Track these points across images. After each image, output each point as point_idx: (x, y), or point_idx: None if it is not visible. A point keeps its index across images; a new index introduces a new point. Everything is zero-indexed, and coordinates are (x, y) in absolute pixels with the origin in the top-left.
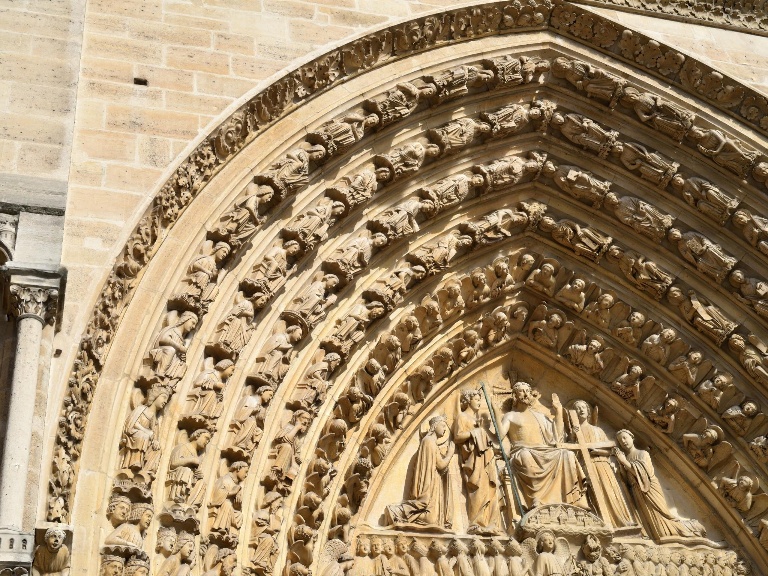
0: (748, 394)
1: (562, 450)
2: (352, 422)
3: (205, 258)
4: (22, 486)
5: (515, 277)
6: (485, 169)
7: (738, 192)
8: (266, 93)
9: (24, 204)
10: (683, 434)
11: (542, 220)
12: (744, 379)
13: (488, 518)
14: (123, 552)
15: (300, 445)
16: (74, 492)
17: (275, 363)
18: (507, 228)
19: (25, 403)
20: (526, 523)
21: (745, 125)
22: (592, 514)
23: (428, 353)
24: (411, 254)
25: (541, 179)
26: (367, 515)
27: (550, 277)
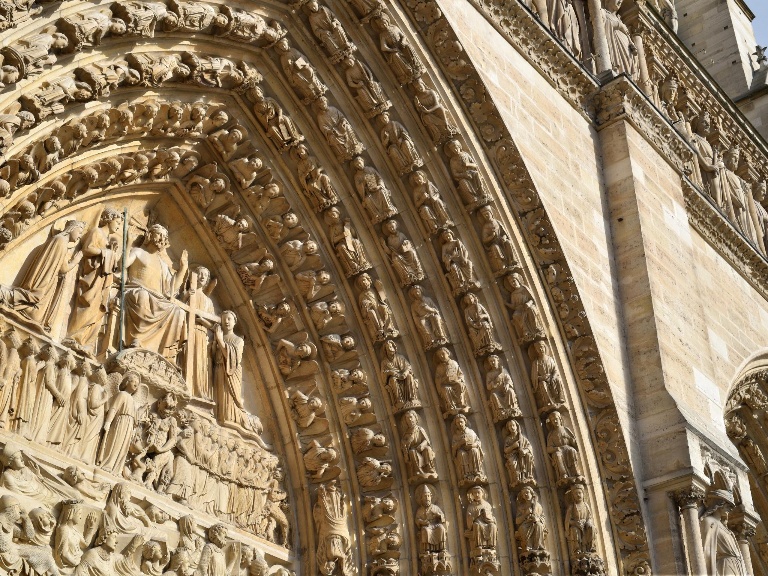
0: (351, 329)
1: (176, 305)
2: None
3: None
4: None
5: (202, 126)
6: (233, 14)
7: (426, 154)
8: None
9: None
10: (281, 338)
11: (254, 88)
12: (354, 315)
13: (86, 338)
14: None
15: None
16: None
17: None
18: (221, 78)
19: None
20: (122, 358)
21: (458, 101)
22: (180, 375)
23: (98, 157)
24: (133, 55)
25: (269, 50)
26: None
27: (234, 143)
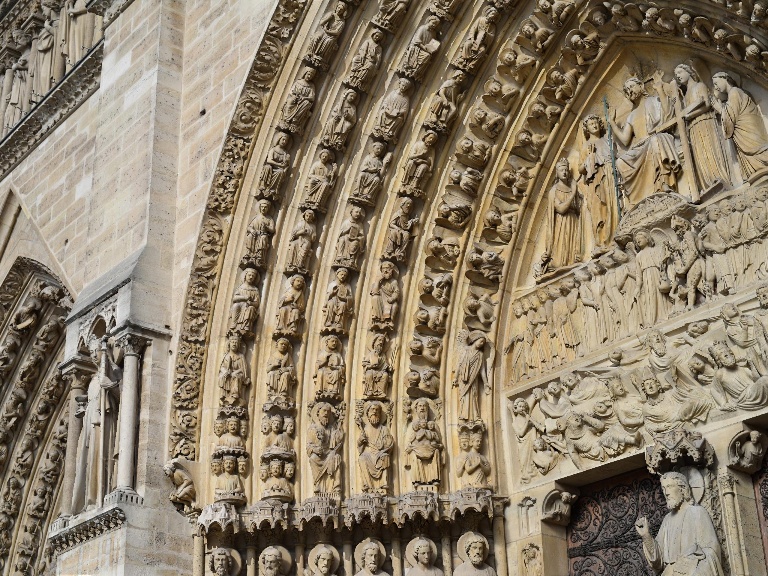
0: None
1: None
2: (462, 227)
3: (255, 219)
4: (124, 461)
5: None
6: None
7: None
8: (257, 63)
9: (117, 285)
10: None
11: None
12: None
13: None
14: (218, 455)
15: (395, 286)
16: (198, 428)
17: (341, 248)
18: None
19: (124, 412)
20: (617, 234)
21: None
22: (672, 194)
23: (523, 120)
24: None
25: None
26: (524, 279)
27: None
